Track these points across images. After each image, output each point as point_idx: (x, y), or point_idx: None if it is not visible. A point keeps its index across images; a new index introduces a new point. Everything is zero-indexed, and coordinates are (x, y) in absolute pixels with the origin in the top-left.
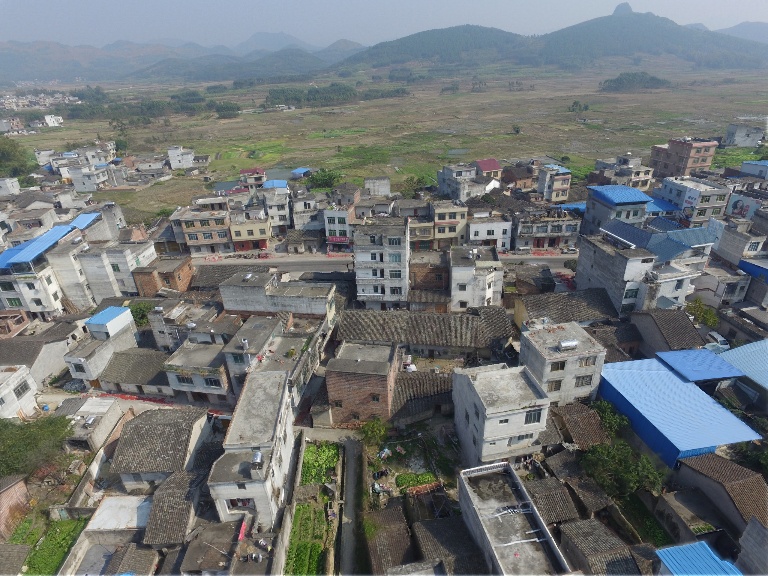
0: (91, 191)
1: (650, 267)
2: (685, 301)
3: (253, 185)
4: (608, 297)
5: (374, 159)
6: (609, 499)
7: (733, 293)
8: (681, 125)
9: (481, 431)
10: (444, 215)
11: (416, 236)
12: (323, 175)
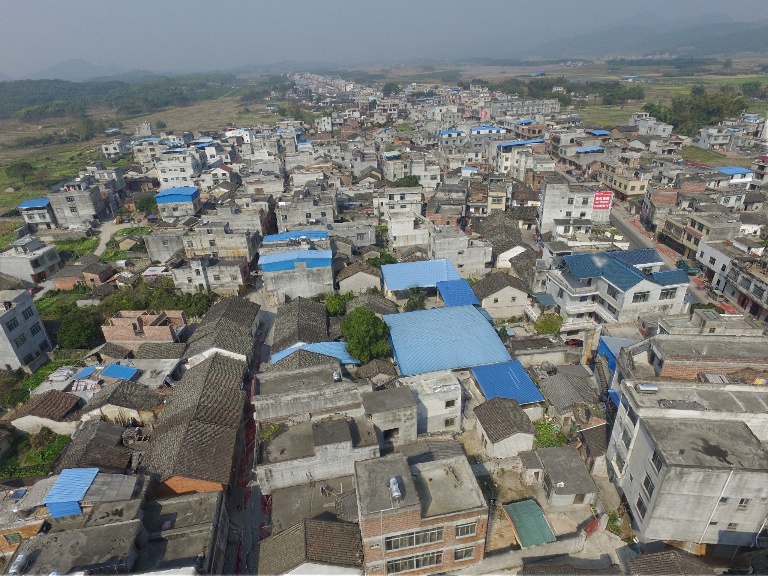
0: (704, 149)
1: None
2: None
3: (754, 172)
4: None
5: None
6: None
7: None
8: None
9: None
10: (695, 223)
11: None
12: None
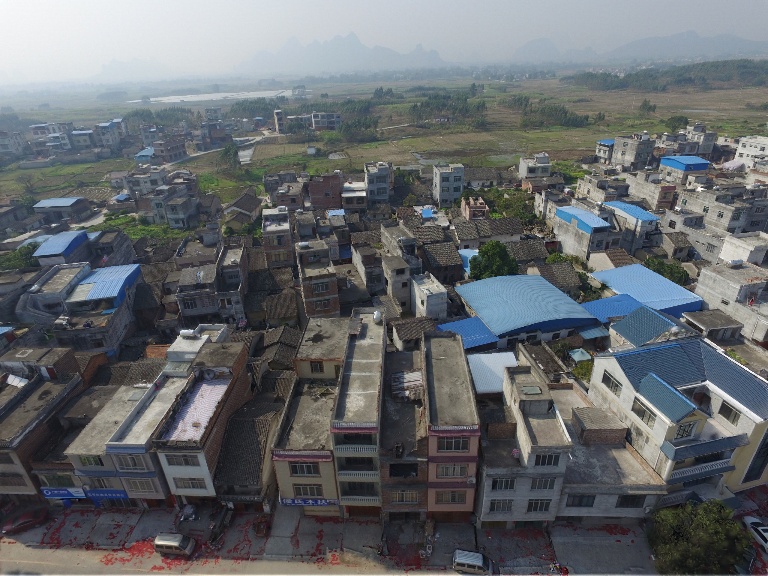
0: None
1: None
2: None
3: None
4: None
5: None
6: None
7: None
8: None
9: None
10: None
11: None
12: None
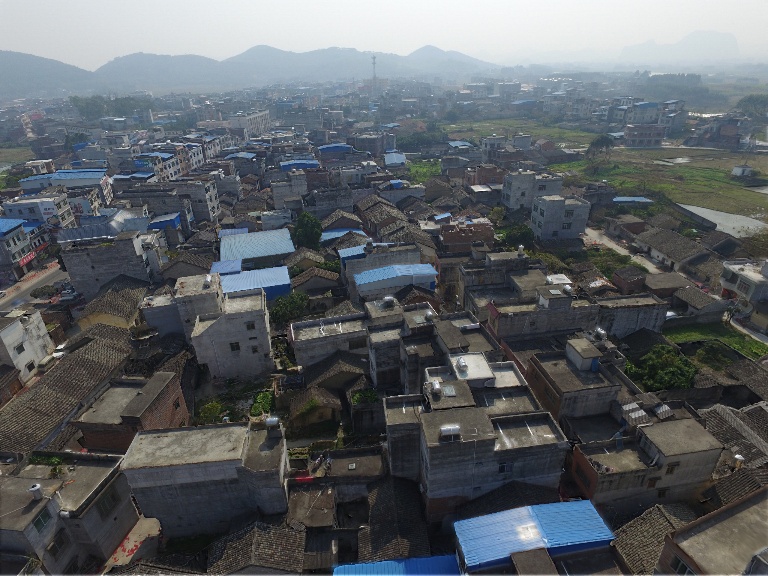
0: None
1: (141, 240)
2: None
3: None
4: (131, 277)
5: None
6: (306, 317)
7: None
8: None
9: (263, 331)
10: None
11: None
12: None
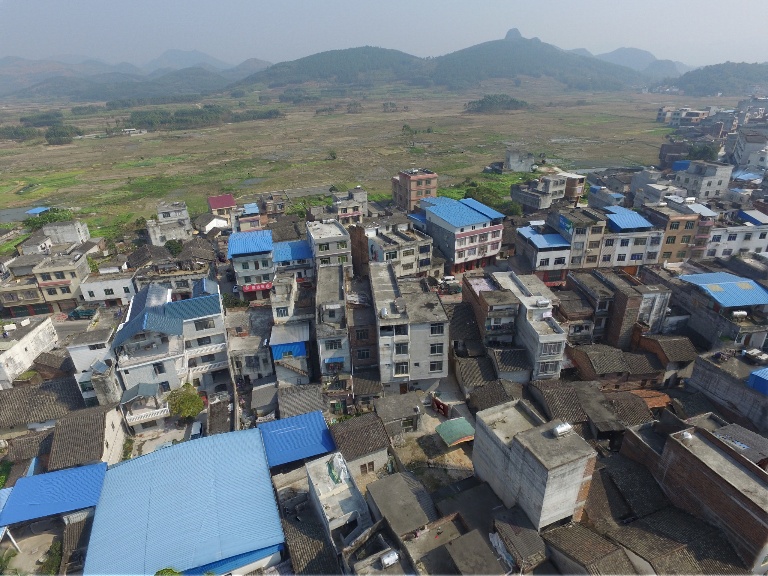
0: None
1: (106, 353)
2: (189, 383)
3: None
4: None
5: (153, 192)
6: None
7: (258, 367)
8: (495, 148)
9: None
10: (48, 275)
11: (19, 300)
12: (44, 217)
